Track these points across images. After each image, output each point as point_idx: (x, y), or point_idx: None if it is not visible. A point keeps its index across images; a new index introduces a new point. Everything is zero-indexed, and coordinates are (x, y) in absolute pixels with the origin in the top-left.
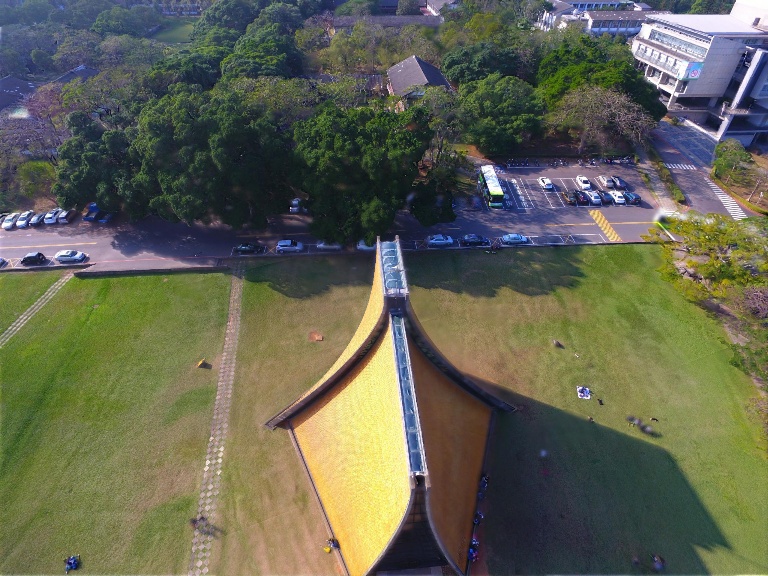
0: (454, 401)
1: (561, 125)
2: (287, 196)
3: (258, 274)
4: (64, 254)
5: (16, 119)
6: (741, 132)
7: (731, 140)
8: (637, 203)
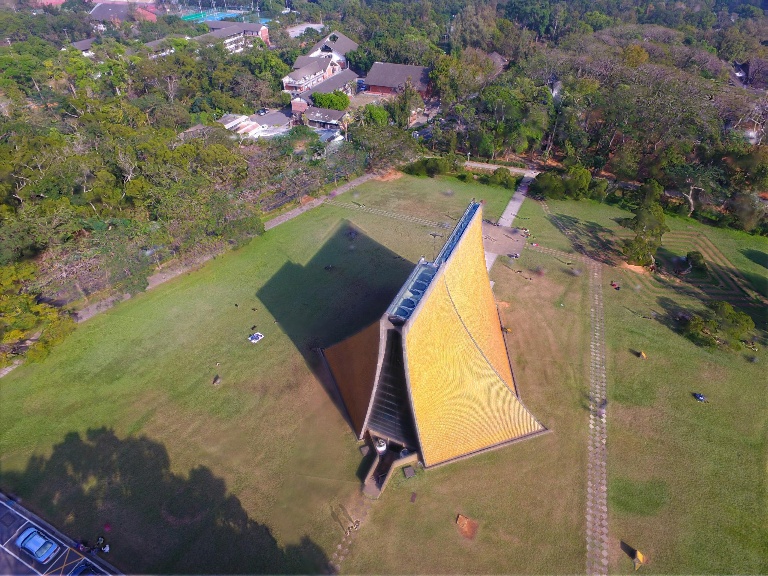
0: None
1: None
2: None
3: None
4: None
5: None
6: None
7: None
8: None
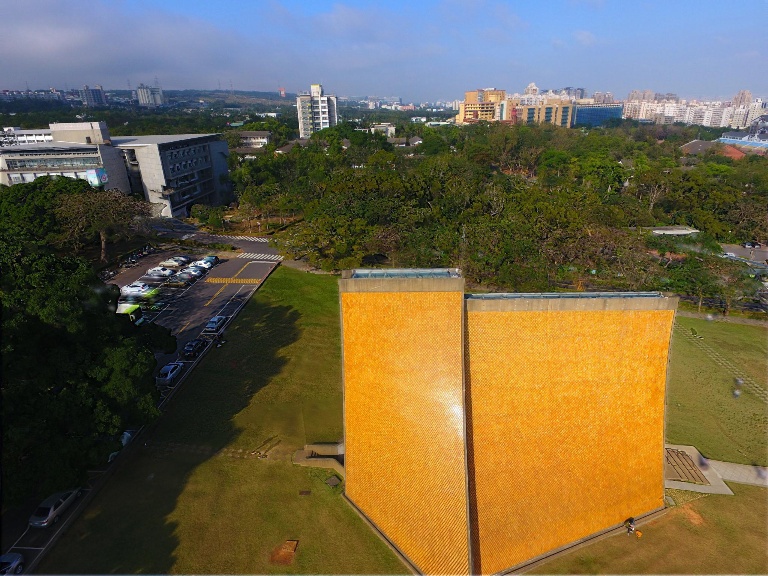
0: None
1: (88, 234)
2: None
3: None
4: None
5: None
6: (179, 207)
7: (197, 206)
8: (218, 261)
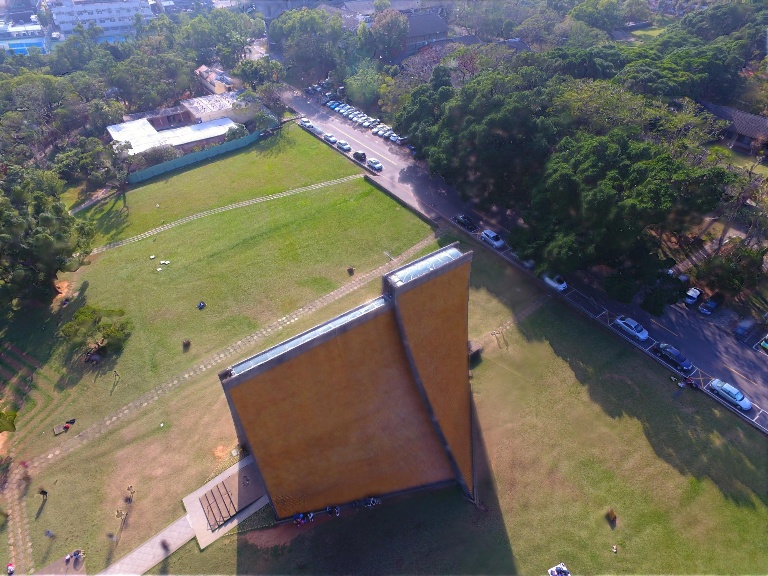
0: (409, 423)
1: None
2: (525, 197)
3: (449, 243)
4: (372, 160)
5: (417, 61)
6: None
7: None
8: None
